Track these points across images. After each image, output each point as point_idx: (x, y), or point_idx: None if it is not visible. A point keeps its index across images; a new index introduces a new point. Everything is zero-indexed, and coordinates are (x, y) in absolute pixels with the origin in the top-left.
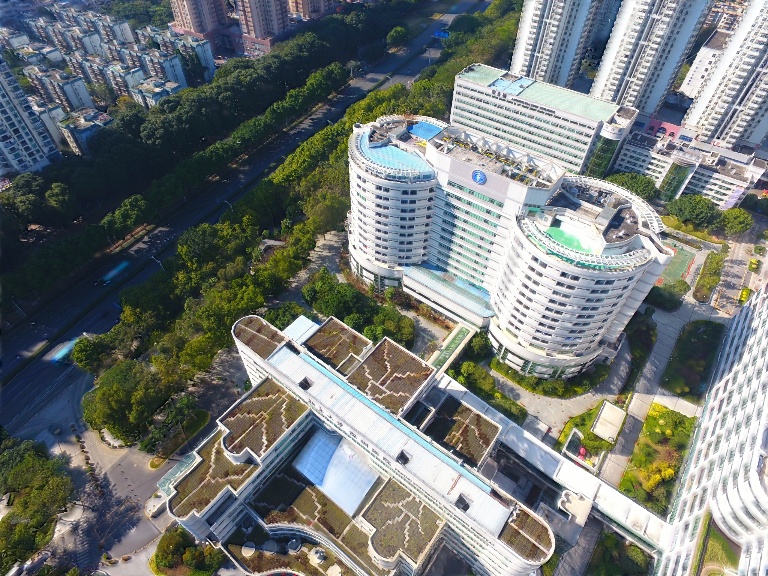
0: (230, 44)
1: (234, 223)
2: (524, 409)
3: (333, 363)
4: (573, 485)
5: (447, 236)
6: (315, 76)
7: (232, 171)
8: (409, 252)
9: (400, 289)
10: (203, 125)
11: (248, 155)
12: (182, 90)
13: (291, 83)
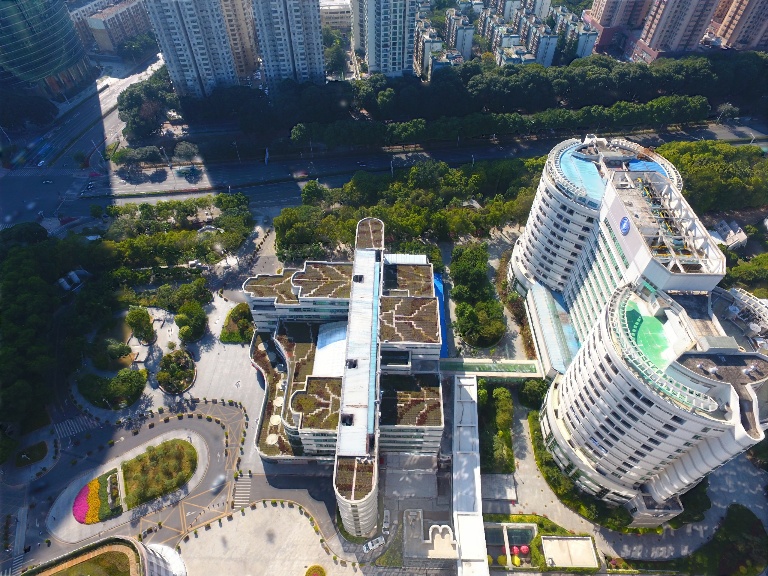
0: (624, 45)
1: (465, 175)
2: (514, 467)
3: None
4: (462, 534)
5: (583, 276)
6: (663, 99)
7: (512, 143)
8: (547, 271)
9: (524, 301)
10: (521, 97)
11: (538, 138)
12: (532, 64)
13: (642, 99)
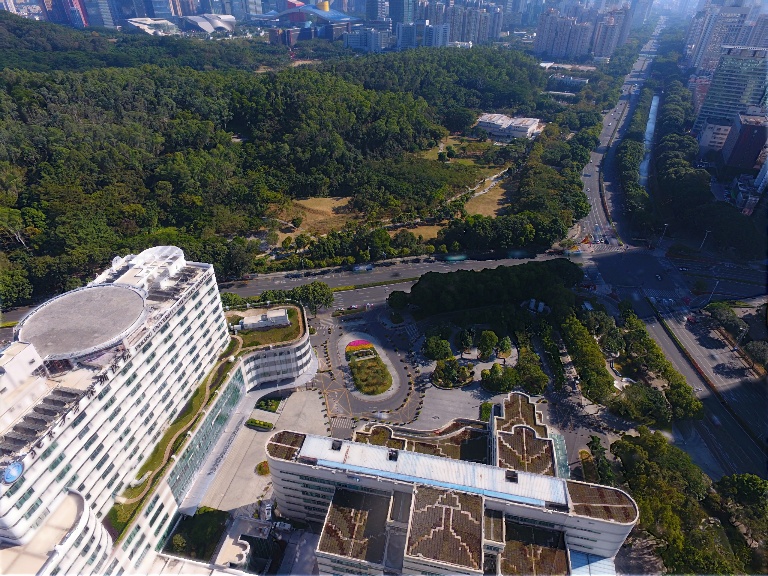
0: None
1: None
2: None
3: (518, 539)
4: None
5: None
6: None
7: None
8: None
9: None
10: None
11: None
12: None
13: None
